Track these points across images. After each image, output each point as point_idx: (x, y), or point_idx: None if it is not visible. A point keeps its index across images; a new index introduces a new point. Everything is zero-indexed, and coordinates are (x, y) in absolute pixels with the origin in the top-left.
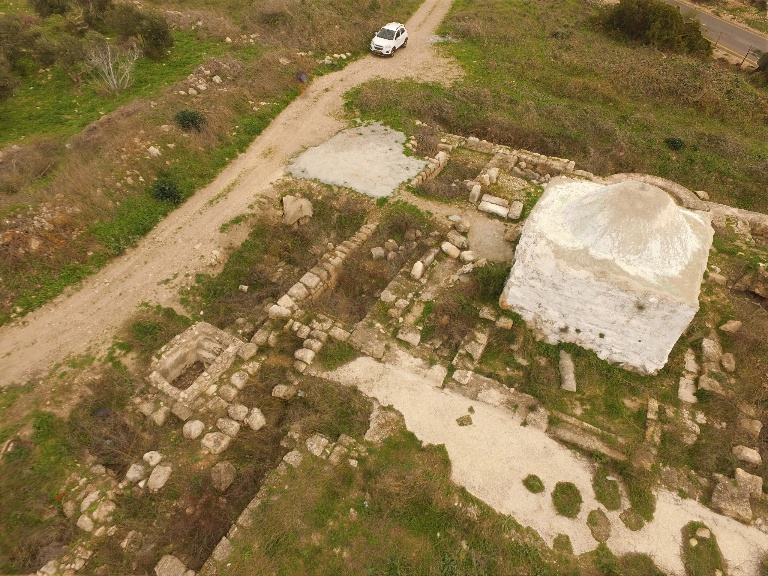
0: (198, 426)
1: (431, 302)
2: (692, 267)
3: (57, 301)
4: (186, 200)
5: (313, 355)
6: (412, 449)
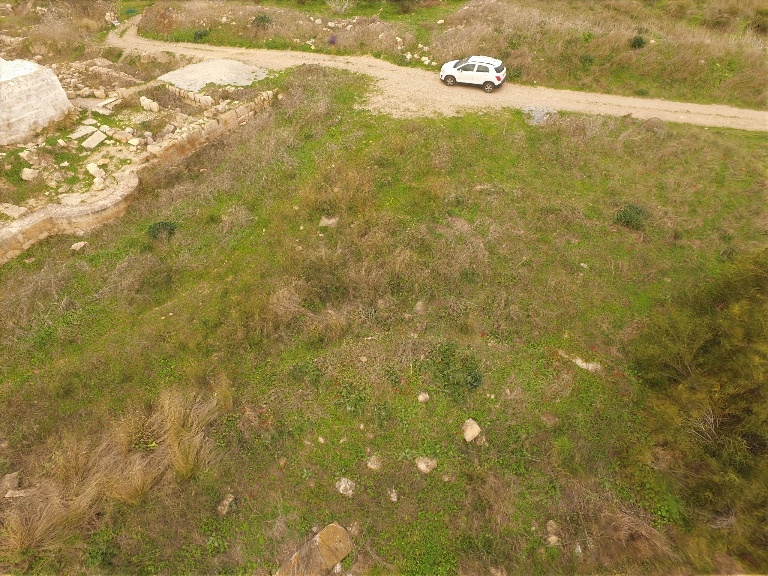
0: (53, 66)
1: None
2: None
3: (145, 39)
4: (199, 43)
5: (62, 77)
6: None
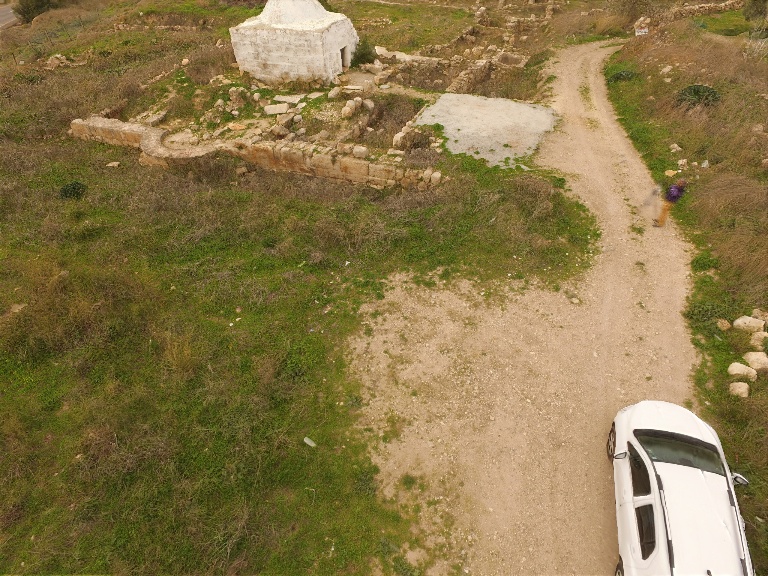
0: None
1: (398, 63)
2: None
3: None
4: None
5: None
6: None
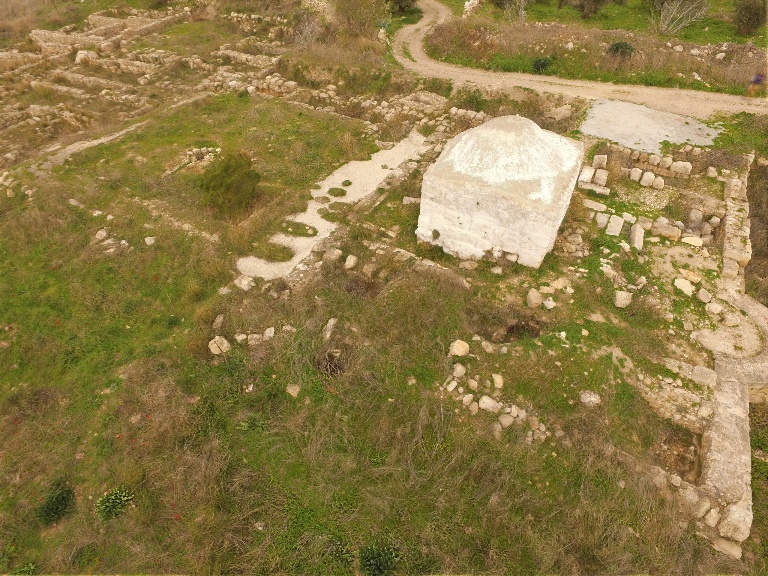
0: (385, 104)
1: None
2: (465, 177)
3: (452, 65)
4: (542, 74)
5: None
6: (369, 151)
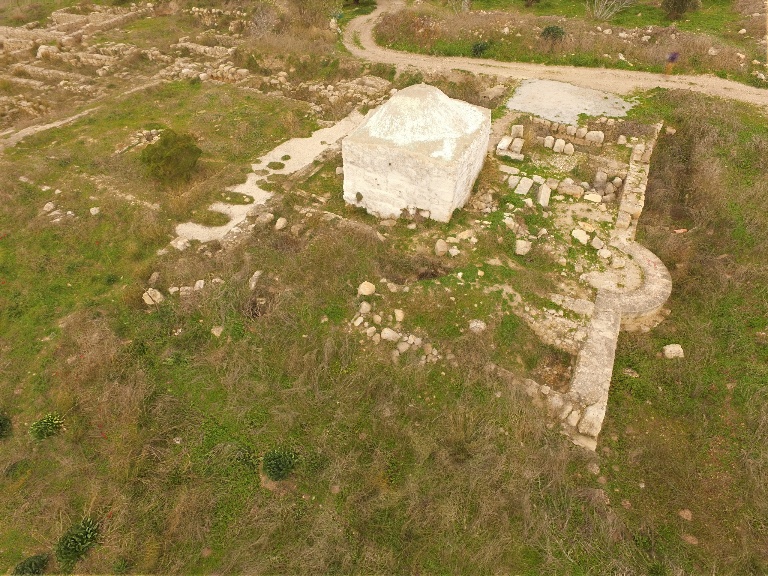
0: (330, 87)
1: None
2: (378, 140)
3: None
4: (480, 58)
5: None
6: (311, 129)
